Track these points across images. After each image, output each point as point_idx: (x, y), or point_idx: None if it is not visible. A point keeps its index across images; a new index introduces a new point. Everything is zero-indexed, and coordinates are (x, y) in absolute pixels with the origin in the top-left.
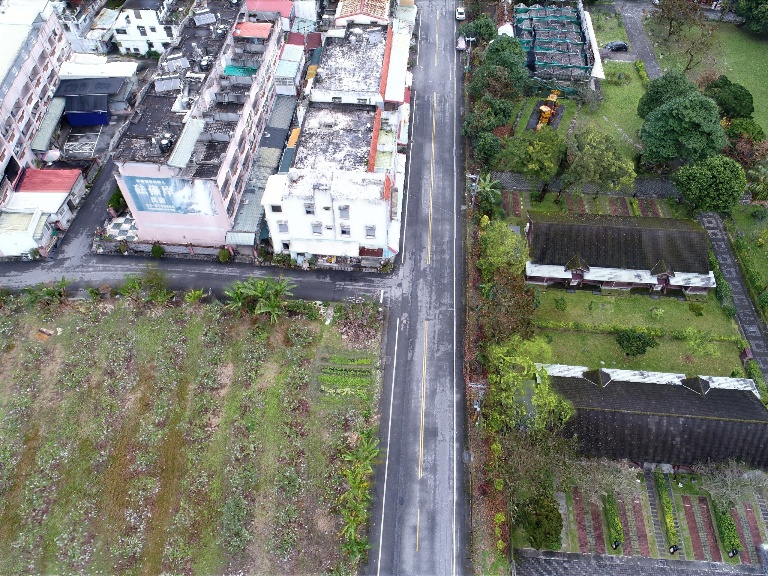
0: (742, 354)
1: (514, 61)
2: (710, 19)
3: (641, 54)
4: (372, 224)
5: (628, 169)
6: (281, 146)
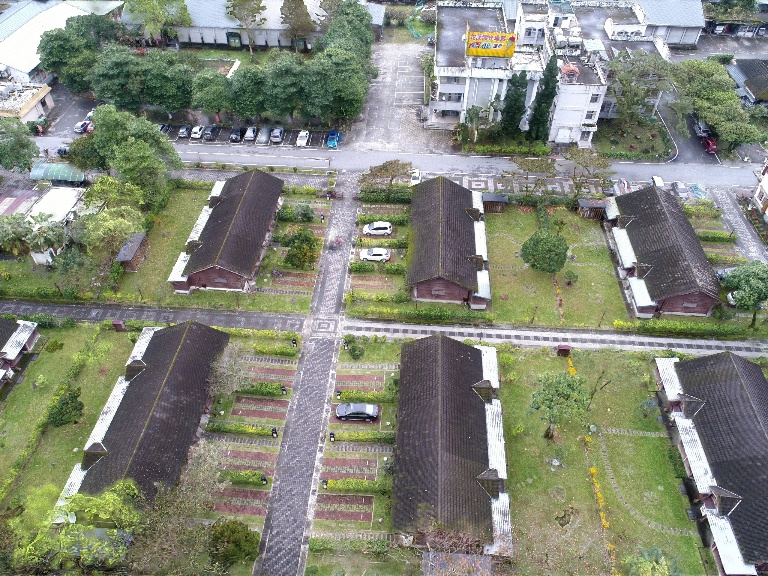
0: (116, 328)
1: None
2: None
3: None
4: None
5: None
6: None
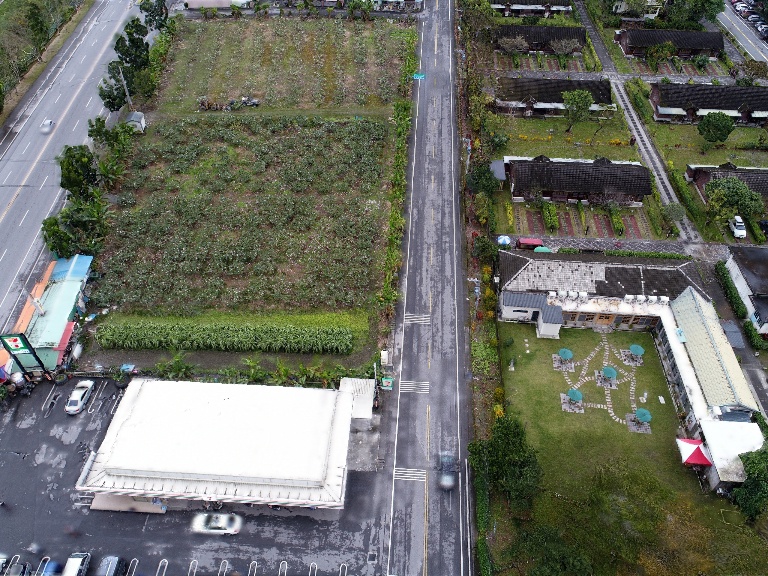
0: None
1: None
2: None
3: None
4: None
5: None
6: None
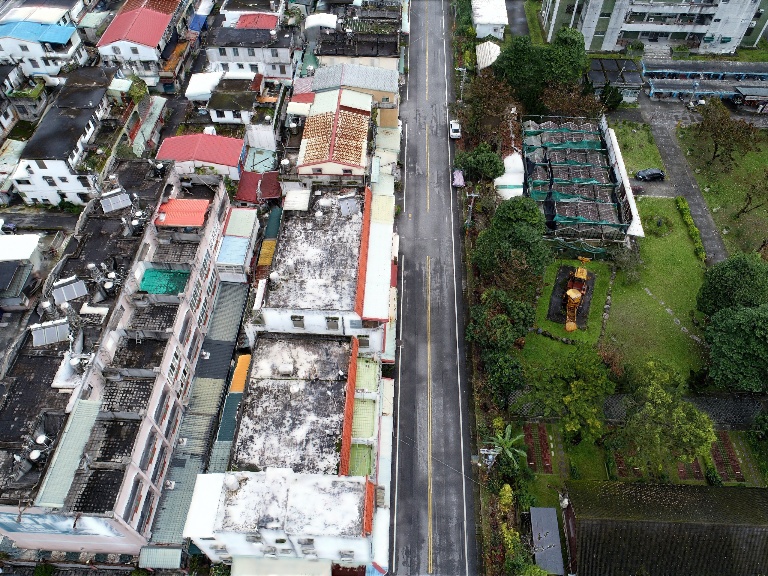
0: None
1: (533, 239)
2: (758, 128)
3: (681, 185)
4: (348, 549)
5: (707, 437)
6: (224, 374)
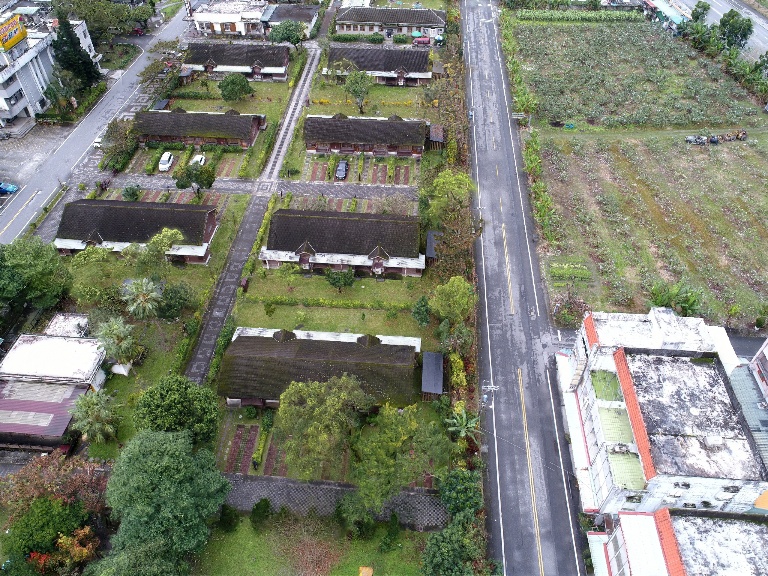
0: None
1: None
2: None
3: None
4: None
5: None
6: None
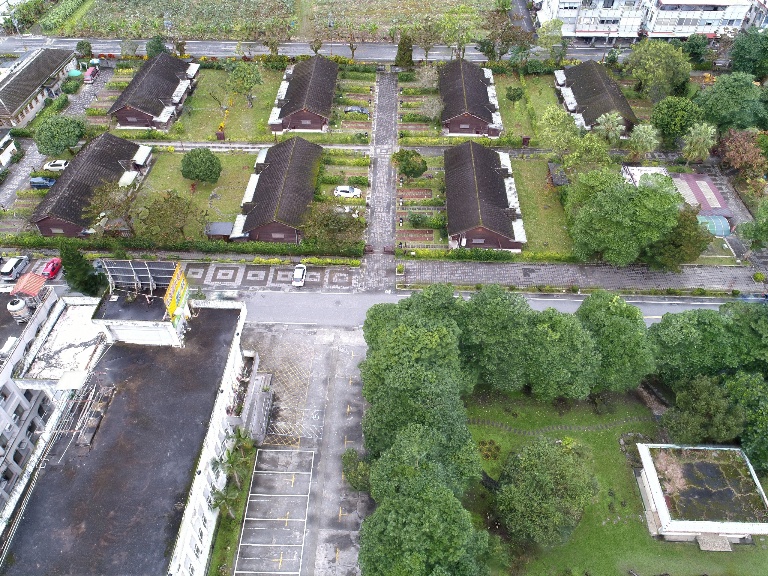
0: None
1: None
2: None
3: None
4: None
5: None
6: None
